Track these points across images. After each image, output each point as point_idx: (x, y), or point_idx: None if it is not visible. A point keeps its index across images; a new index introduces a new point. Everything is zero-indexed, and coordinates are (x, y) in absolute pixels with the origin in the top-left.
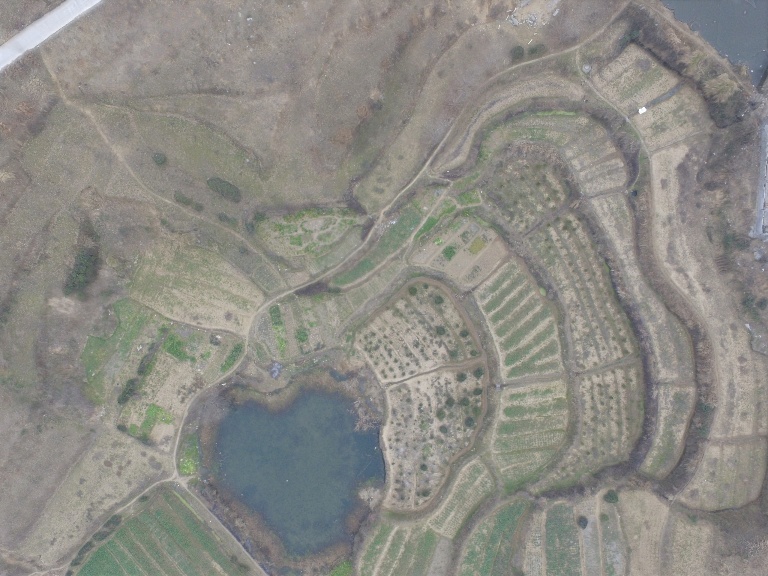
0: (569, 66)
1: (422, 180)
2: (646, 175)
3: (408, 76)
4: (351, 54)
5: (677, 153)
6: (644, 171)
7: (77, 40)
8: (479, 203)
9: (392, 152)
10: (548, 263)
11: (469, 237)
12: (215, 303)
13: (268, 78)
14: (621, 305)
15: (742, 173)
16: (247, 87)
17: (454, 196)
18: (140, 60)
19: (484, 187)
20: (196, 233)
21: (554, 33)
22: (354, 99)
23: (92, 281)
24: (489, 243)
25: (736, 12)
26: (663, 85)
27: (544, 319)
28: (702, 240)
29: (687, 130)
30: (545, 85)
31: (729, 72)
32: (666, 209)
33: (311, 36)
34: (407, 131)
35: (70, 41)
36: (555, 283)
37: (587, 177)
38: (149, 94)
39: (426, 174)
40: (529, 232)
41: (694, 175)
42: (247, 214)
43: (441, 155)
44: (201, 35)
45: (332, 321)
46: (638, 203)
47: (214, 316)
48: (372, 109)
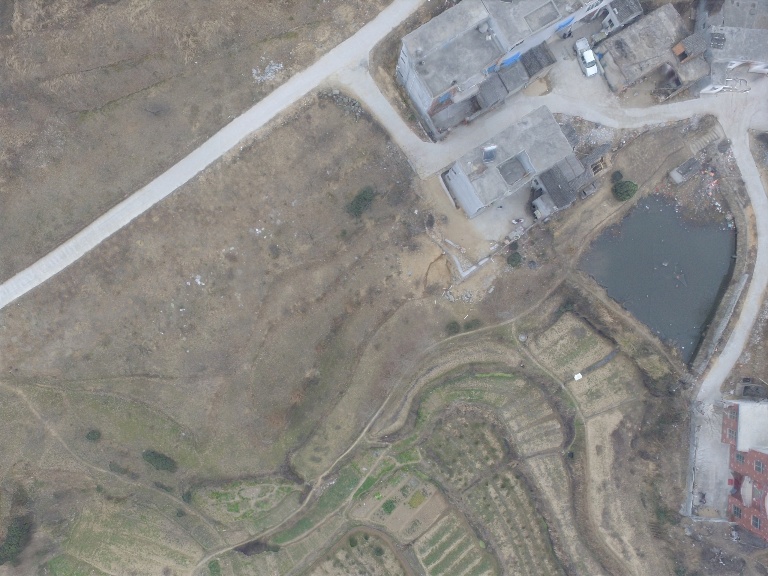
0: (505, 336)
1: (360, 446)
2: (582, 441)
3: (344, 352)
4: (286, 338)
5: (612, 420)
6: (580, 436)
7: (7, 327)
8: (419, 460)
9: (329, 422)
10: (487, 520)
11: (409, 491)
12: (154, 558)
13: (202, 366)
14: (558, 562)
15: (673, 452)
16: (181, 373)
17: (393, 455)
18: (72, 347)
19: (424, 444)
20: (133, 498)
21: (490, 309)
22: (289, 381)
23: (26, 546)
24: (429, 497)
25: (668, 286)
26: (598, 353)
27: (483, 572)
28: (636, 505)
29: (621, 397)
30: (482, 351)
31: (660, 351)
32: (601, 475)
33: (245, 325)
34: (344, 402)
35: (0, 328)
36: (494, 539)
37: (525, 438)
38: (81, 378)
39: (364, 440)
40: (468, 488)
41: (628, 441)
42: (183, 484)
43: (379, 420)
44: (134, 324)
45: (272, 575)
46: (574, 467)
47: (153, 572)
48: (308, 386)
